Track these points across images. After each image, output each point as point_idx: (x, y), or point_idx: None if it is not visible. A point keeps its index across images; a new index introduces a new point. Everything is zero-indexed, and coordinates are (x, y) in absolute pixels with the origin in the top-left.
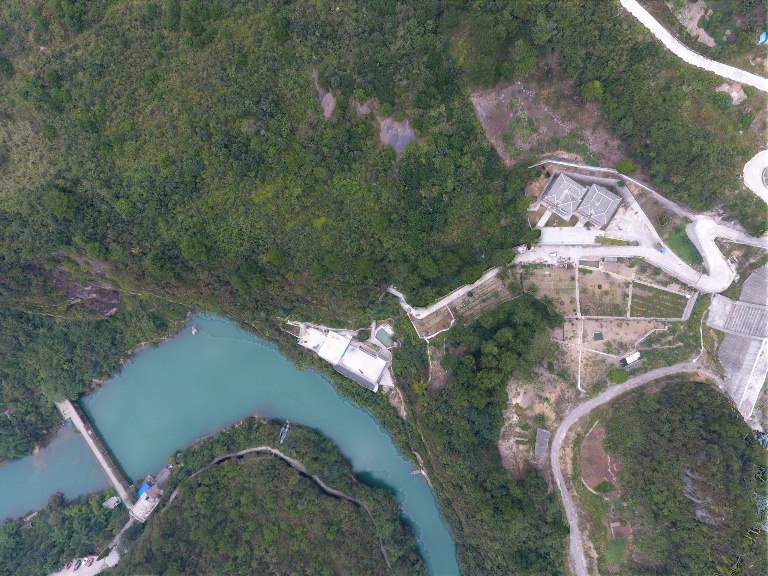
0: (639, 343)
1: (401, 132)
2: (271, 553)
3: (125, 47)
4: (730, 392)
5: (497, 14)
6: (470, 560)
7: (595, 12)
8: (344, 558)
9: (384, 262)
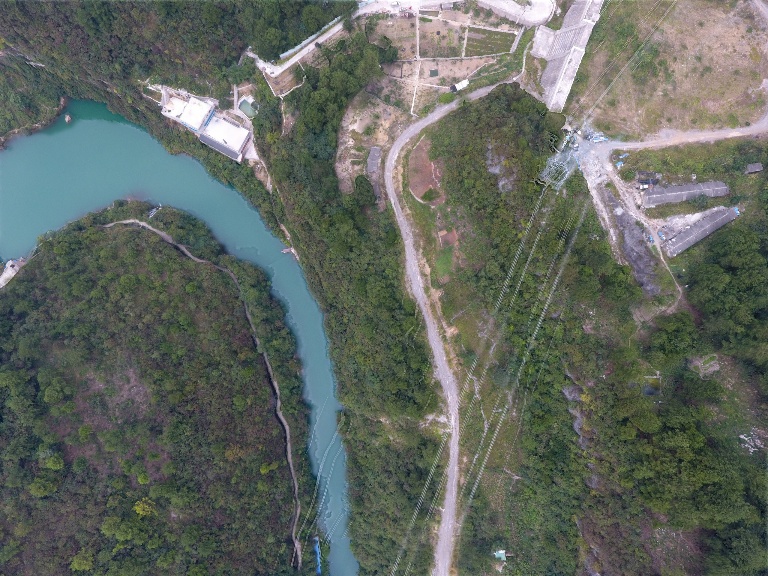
0: (470, 76)
1: None
2: (127, 297)
3: None
4: (546, 105)
5: None
6: (332, 321)
7: None
8: (203, 310)
9: (235, 15)
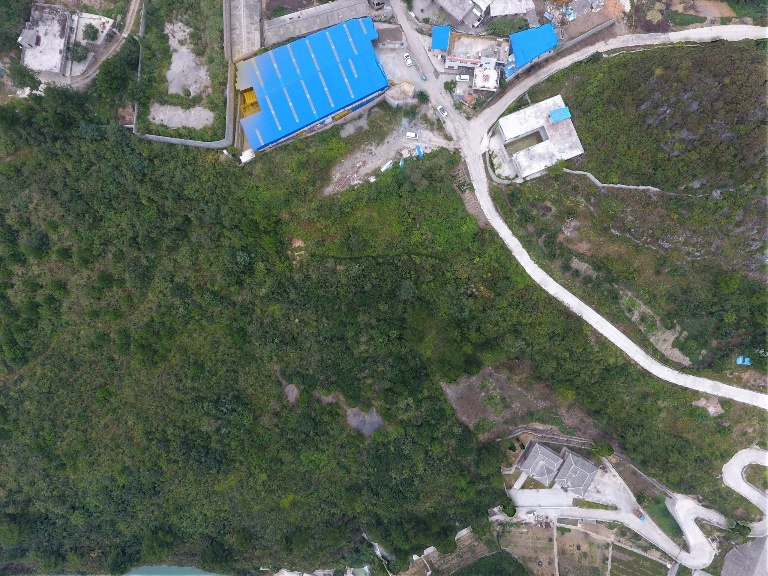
0: None
1: (368, 418)
2: None
3: (74, 370)
4: None
5: (463, 324)
6: None
7: (564, 338)
8: None
9: (357, 520)
